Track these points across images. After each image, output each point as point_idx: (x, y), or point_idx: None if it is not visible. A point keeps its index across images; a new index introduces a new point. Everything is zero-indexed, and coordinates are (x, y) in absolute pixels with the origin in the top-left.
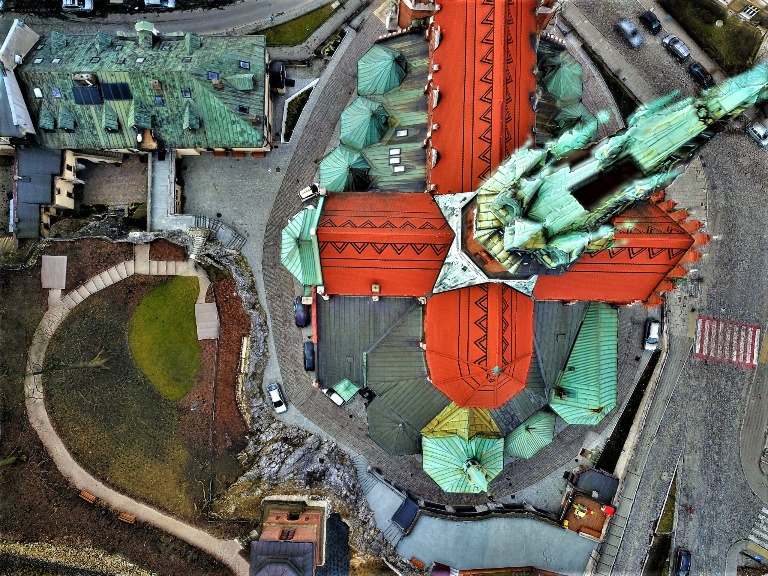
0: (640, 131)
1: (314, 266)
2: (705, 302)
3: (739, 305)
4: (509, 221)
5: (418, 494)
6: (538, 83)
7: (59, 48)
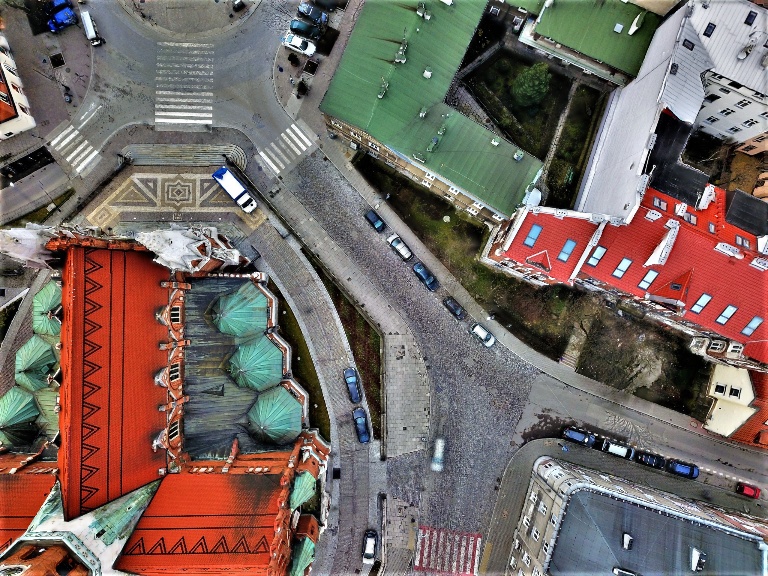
0: None
1: None
2: (426, 512)
3: (460, 514)
4: None
5: None
6: (208, 326)
7: None
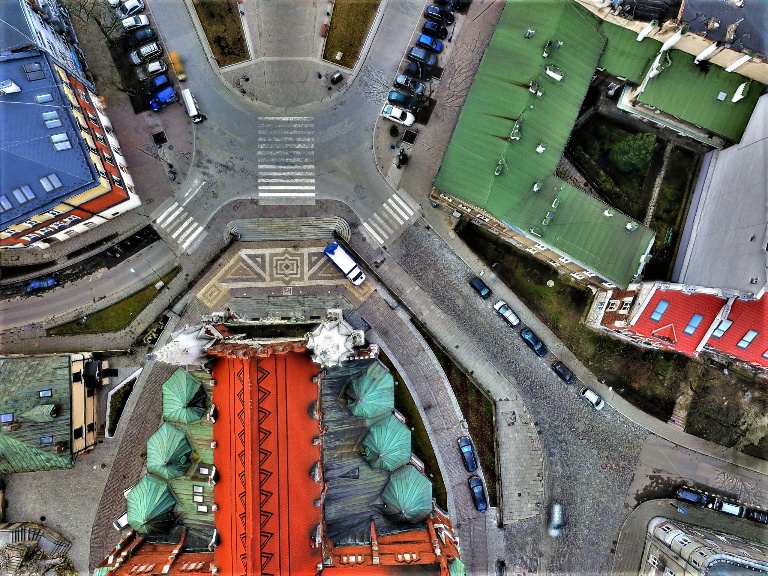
0: None
1: None
2: None
3: None
4: None
5: None
6: (342, 410)
7: None
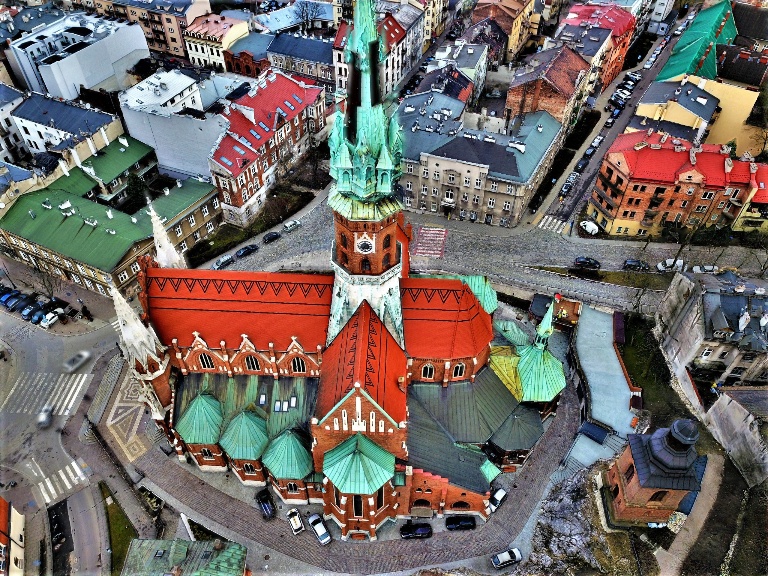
0: (357, 39)
1: (378, 453)
2: None
3: None
4: (374, 182)
5: (576, 431)
6: None
7: None
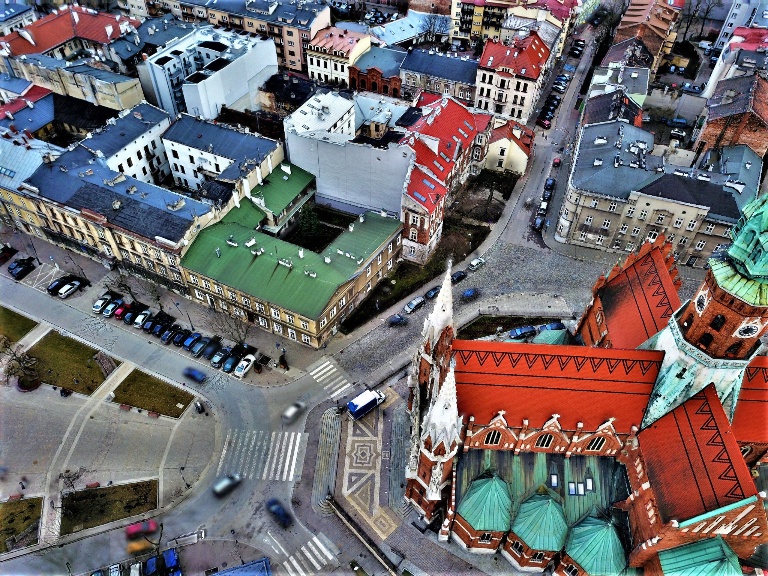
0: None
1: (731, 556)
2: None
3: None
4: None
5: None
6: None
7: None
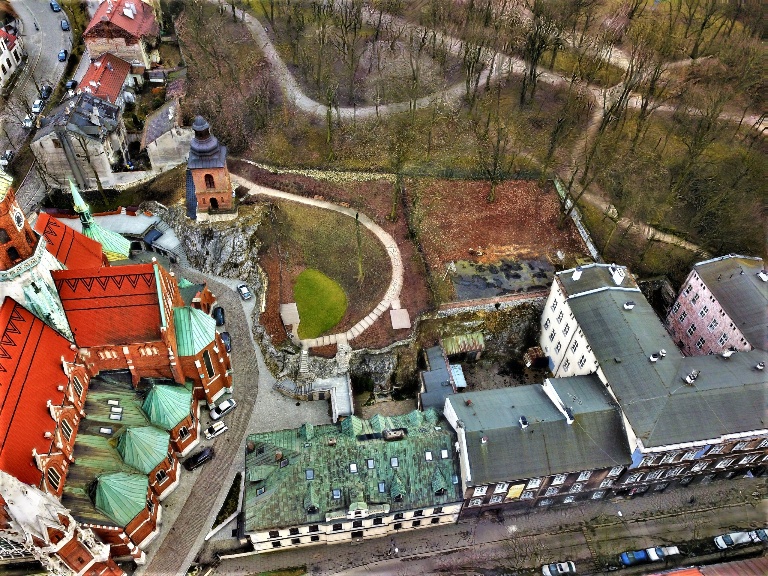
0: None
1: None
2: None
3: None
4: None
5: None
6: None
7: (435, 477)
